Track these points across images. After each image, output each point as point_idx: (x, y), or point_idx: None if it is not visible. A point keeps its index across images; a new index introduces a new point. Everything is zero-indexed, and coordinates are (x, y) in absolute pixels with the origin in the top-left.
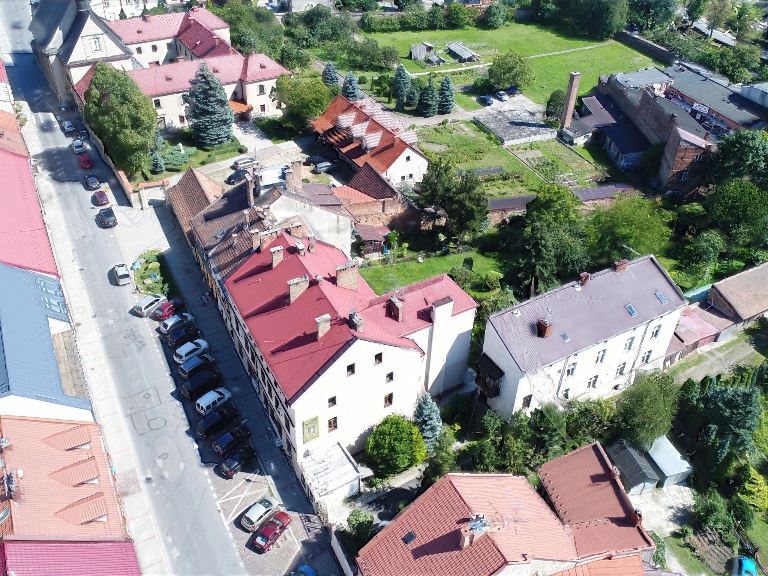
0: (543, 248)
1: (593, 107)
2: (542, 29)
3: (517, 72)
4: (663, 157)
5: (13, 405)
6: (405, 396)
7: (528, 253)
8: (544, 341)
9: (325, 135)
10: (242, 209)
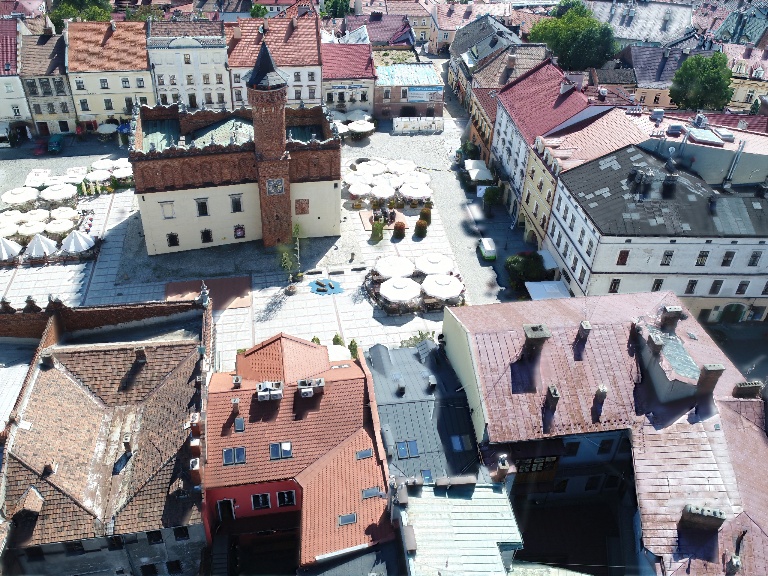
0: None
1: None
2: None
3: None
4: None
5: None
6: None
7: None
8: None
9: (118, 5)
10: None
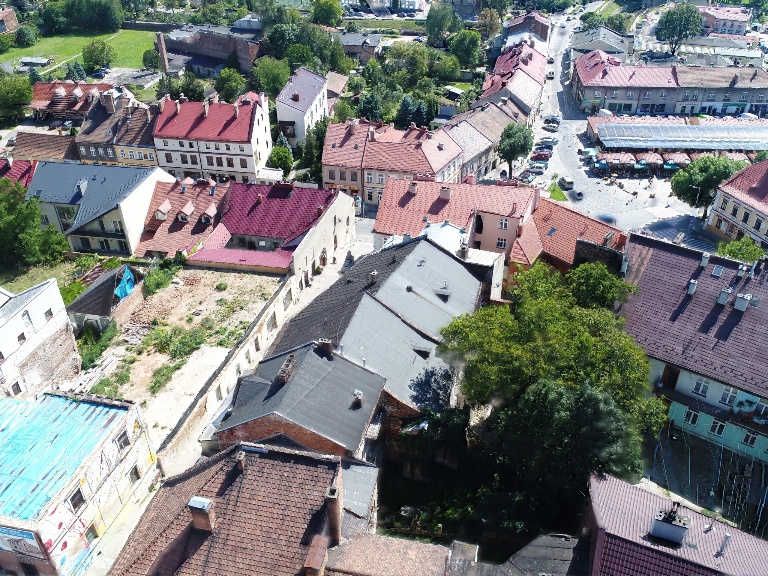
0: (260, 81)
1: (169, 56)
2: (66, 37)
3: (107, 51)
4: (239, 59)
5: (159, 174)
6: (269, 144)
7: (254, 87)
8: (300, 102)
9: (50, 108)
10: (109, 117)
